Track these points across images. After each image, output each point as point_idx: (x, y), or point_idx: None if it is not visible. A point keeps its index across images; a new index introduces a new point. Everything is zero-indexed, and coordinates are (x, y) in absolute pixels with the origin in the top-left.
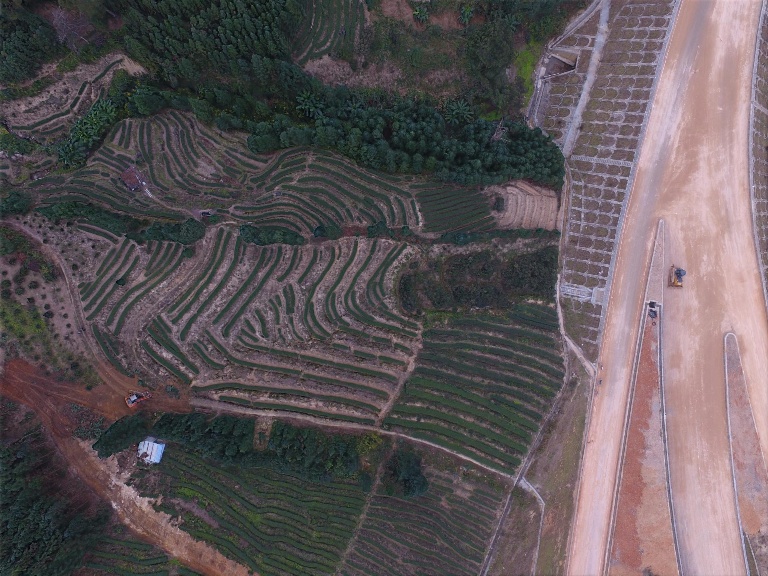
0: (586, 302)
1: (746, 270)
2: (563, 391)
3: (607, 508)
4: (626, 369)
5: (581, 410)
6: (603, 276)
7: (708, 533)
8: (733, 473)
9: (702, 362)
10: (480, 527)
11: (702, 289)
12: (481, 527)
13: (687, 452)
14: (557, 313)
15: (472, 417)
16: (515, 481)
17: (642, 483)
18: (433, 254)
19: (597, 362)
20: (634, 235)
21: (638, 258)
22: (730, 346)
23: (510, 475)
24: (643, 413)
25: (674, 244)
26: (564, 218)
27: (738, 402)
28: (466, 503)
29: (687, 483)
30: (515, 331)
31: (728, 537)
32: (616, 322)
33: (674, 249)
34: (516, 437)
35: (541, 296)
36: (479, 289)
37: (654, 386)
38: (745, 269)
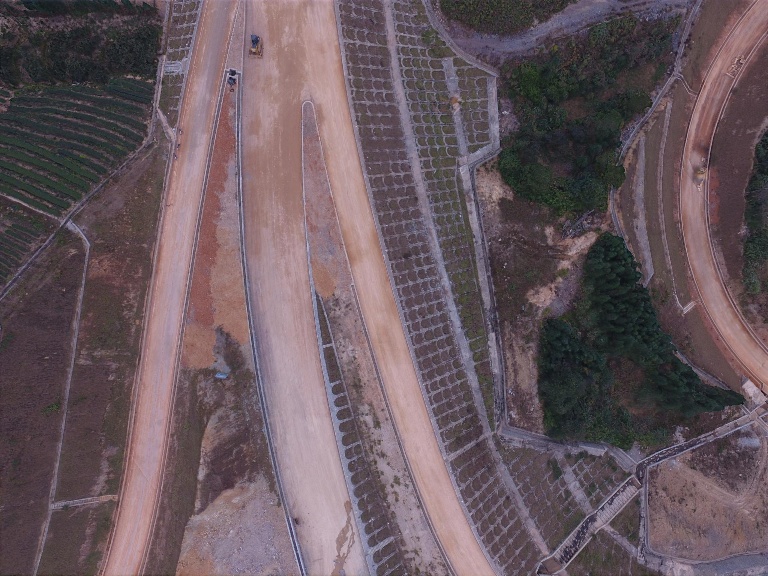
0: (176, 74)
1: (327, 42)
2: (139, 153)
3: (186, 270)
4: (206, 135)
5: (159, 173)
6: (188, 46)
7: (281, 294)
8: (306, 235)
9: (280, 129)
10: (11, 257)
11: (283, 59)
12: (12, 258)
13: (263, 216)
14: (155, 88)
15: (32, 166)
16: (62, 222)
17: (216, 244)
18: (33, 29)
19: (176, 127)
20: (217, 6)
21: (221, 28)
22: (306, 113)
23: (57, 217)
24: (219, 176)
25: (257, 16)
26: (171, 1)
27: (313, 167)
28: (1, 236)
29: (262, 245)
30: (105, 101)
31: (301, 298)
32: (197, 90)
33: (256, 20)
34: (73, 185)
35: (144, 74)
36: (74, 62)
37: (231, 150)
38: (326, 41)
